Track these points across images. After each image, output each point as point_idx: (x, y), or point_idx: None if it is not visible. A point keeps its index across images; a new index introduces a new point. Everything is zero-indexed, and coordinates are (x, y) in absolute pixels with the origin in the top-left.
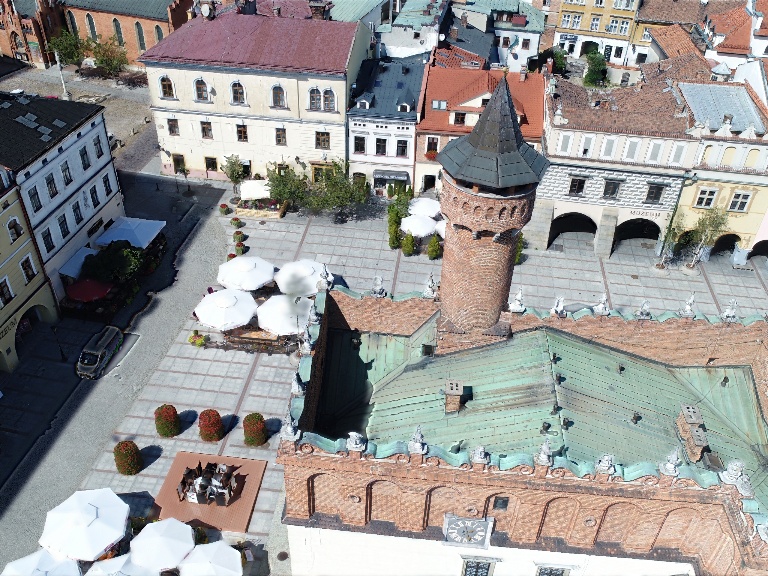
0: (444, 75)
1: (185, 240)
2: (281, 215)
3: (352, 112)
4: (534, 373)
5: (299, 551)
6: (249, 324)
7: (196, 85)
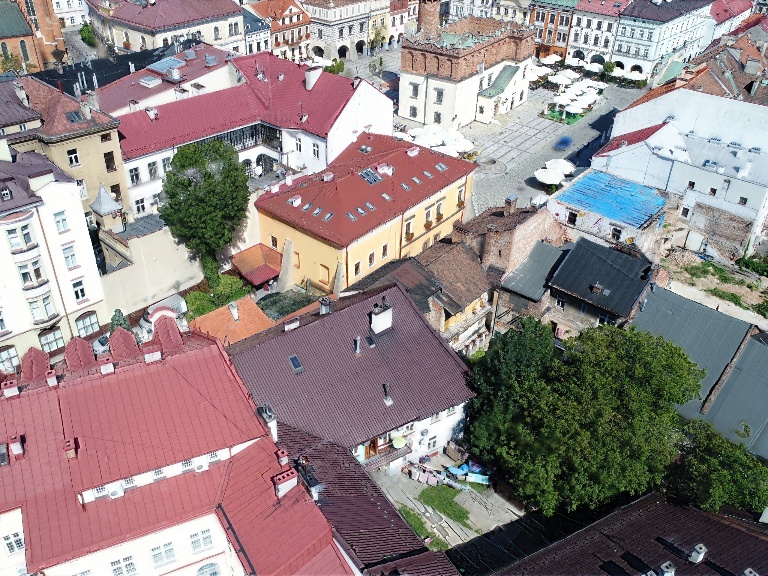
0: (258, 7)
1: None
2: None
3: (247, 31)
4: None
5: None
6: None
7: None
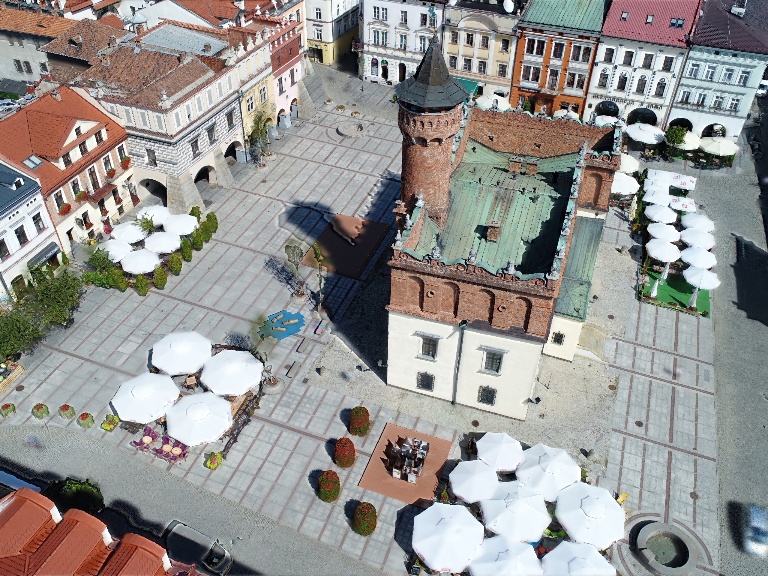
0: None
1: (4, 468)
2: None
3: None
4: (486, 193)
5: None
6: None
7: None
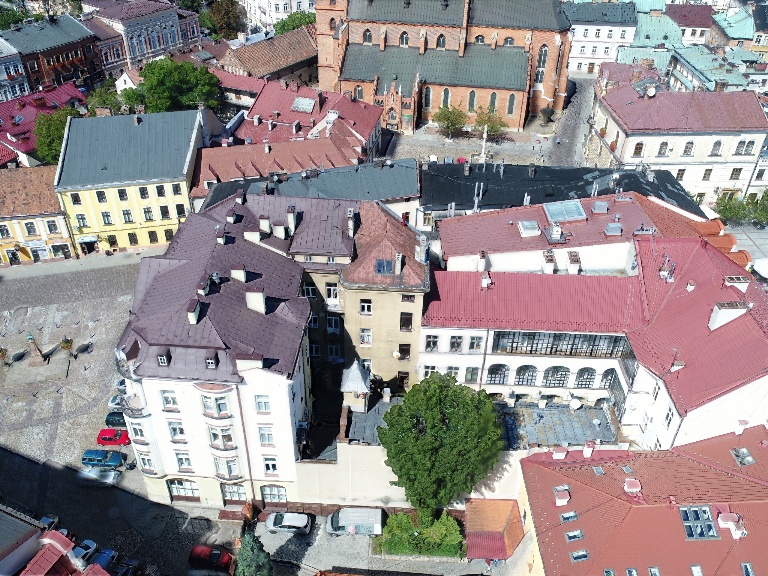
0: None
1: None
2: None
3: (764, 153)
4: None
5: None
6: None
7: (660, 146)
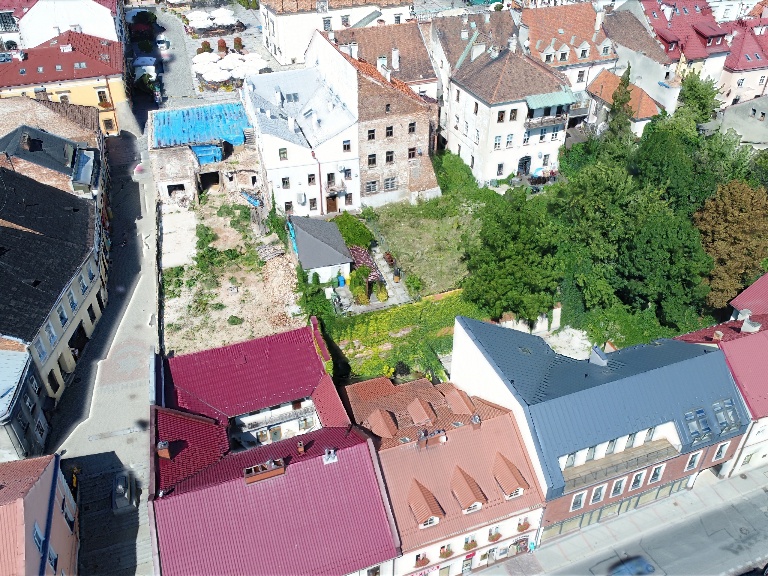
0: None
1: None
2: (190, 9)
3: None
4: None
5: (281, 29)
6: (211, 30)
7: None
